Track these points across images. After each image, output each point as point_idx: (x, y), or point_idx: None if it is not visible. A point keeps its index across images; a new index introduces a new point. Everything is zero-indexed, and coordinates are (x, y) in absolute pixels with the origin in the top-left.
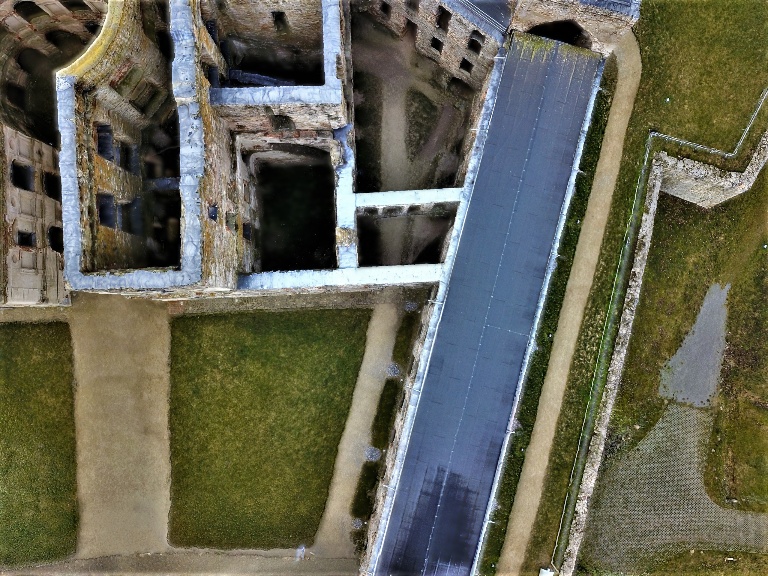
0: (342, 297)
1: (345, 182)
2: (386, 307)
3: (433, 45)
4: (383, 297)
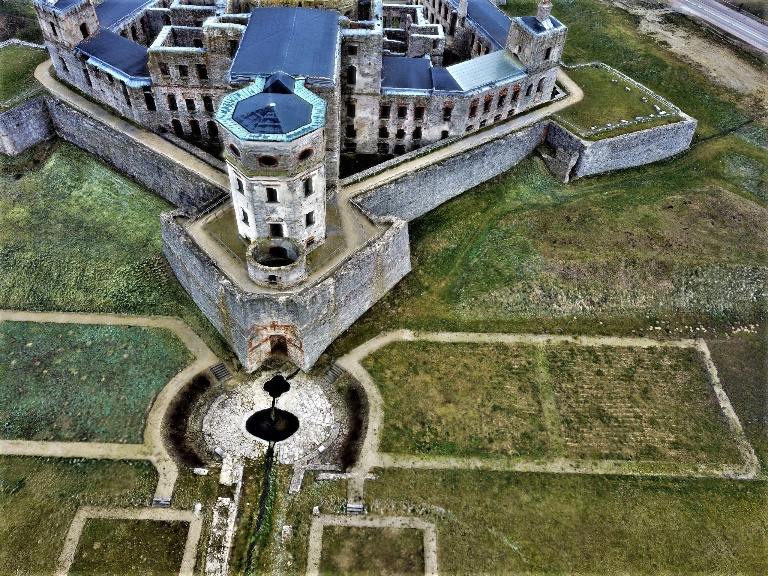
0: None
1: None
2: None
3: None
4: None
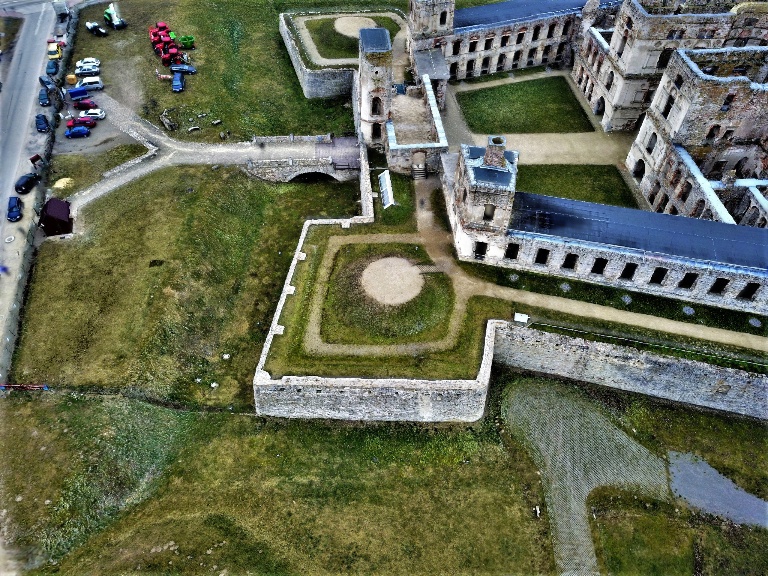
0: None
1: (761, 181)
2: None
3: None
4: None
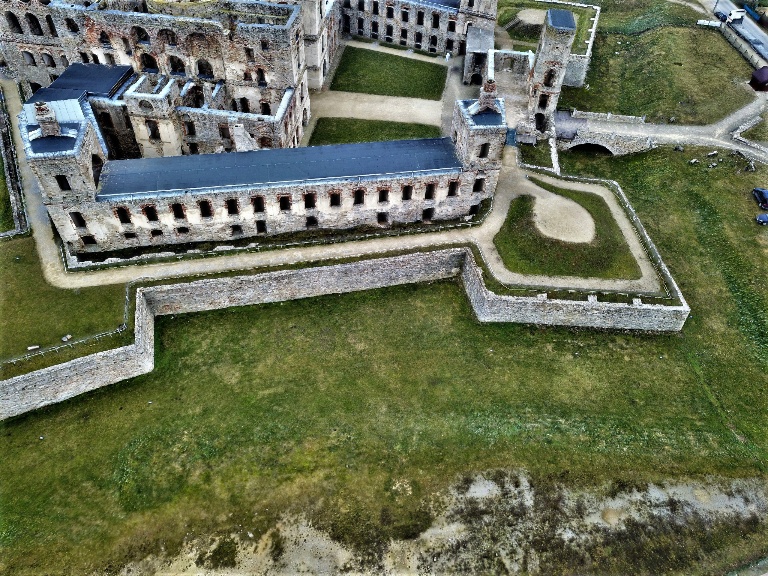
0: (338, 51)
1: None
2: None
3: None
4: None
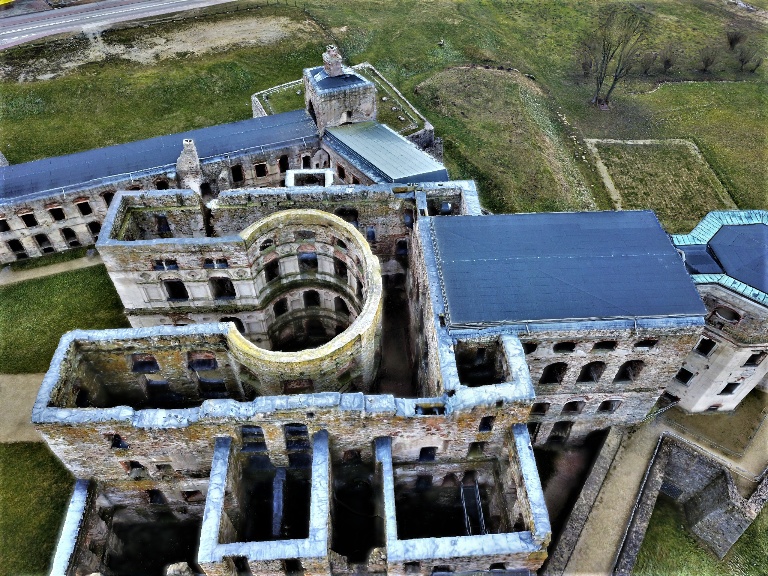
0: None
1: None
2: None
3: None
4: None
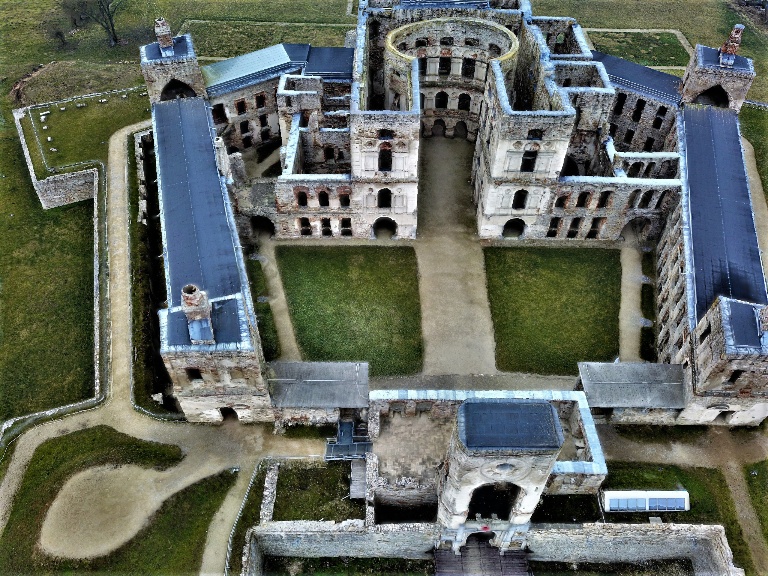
0: (598, 243)
1: (610, 146)
2: (629, 249)
3: (625, 140)
4: (626, 244)
